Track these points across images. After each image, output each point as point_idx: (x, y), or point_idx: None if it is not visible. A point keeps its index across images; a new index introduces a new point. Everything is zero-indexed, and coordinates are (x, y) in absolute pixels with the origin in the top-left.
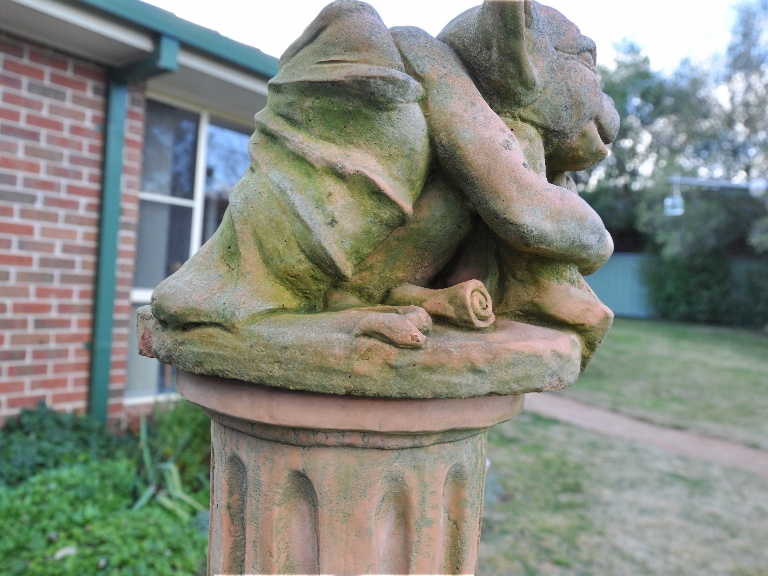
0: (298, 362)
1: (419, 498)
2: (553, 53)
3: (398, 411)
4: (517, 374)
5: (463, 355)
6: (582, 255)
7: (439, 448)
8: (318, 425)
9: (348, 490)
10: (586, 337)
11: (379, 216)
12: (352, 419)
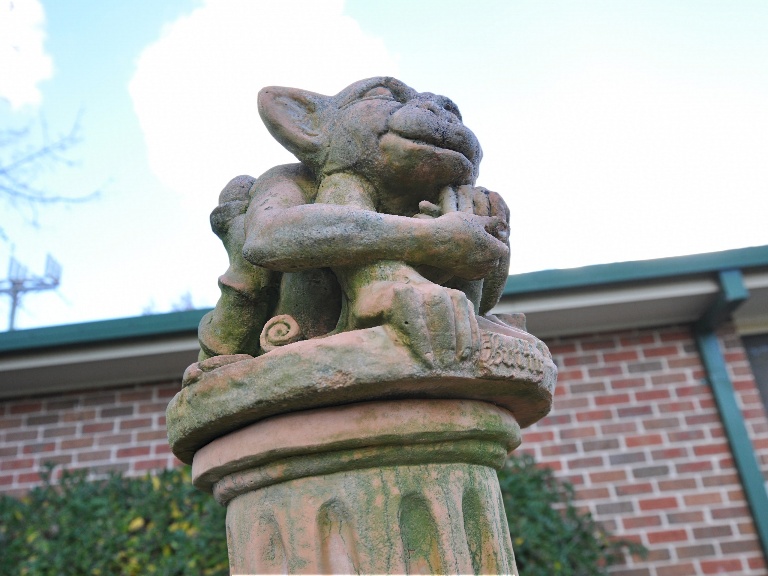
0: None
1: (289, 536)
2: (335, 113)
3: (227, 444)
4: (275, 377)
5: (226, 375)
6: (351, 249)
7: (304, 483)
8: None
9: (241, 534)
10: (395, 324)
11: (230, 302)
12: (207, 460)
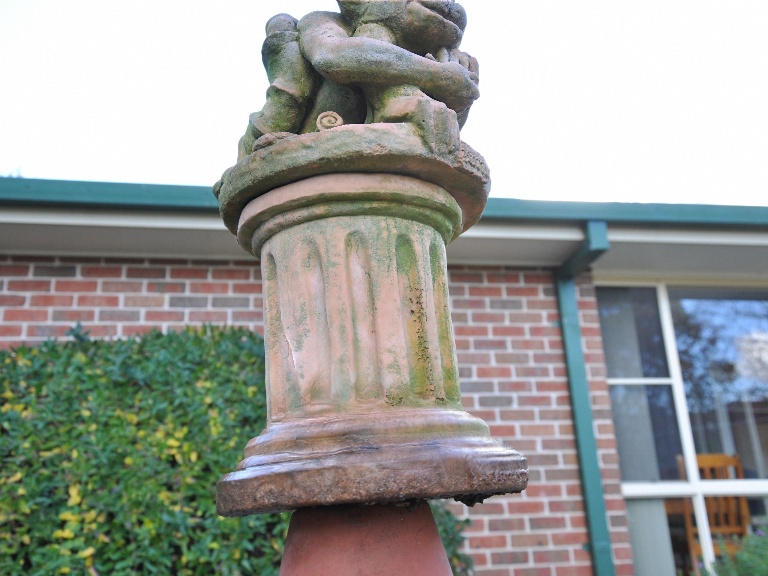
0: (234, 177)
1: (325, 250)
2: None
3: None
4: (336, 144)
5: (297, 141)
6: (390, 71)
7: (337, 220)
8: (256, 212)
9: (286, 253)
10: (415, 122)
11: (282, 102)
12: (267, 202)
